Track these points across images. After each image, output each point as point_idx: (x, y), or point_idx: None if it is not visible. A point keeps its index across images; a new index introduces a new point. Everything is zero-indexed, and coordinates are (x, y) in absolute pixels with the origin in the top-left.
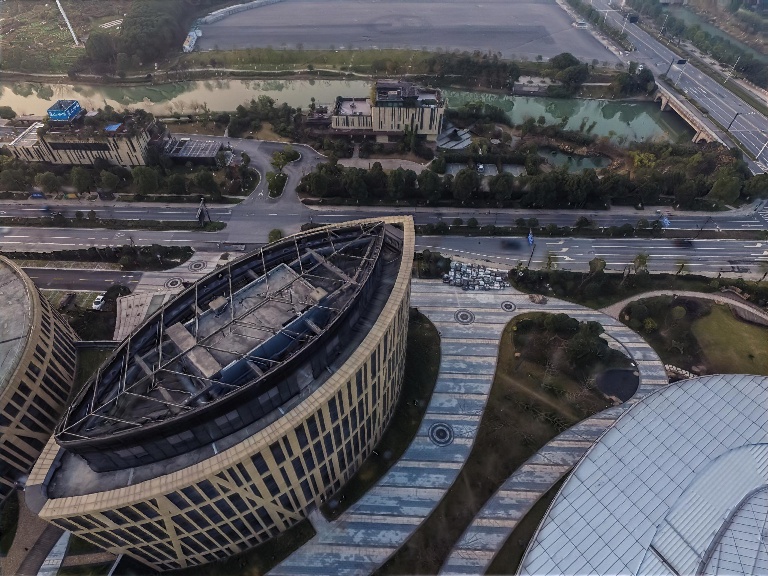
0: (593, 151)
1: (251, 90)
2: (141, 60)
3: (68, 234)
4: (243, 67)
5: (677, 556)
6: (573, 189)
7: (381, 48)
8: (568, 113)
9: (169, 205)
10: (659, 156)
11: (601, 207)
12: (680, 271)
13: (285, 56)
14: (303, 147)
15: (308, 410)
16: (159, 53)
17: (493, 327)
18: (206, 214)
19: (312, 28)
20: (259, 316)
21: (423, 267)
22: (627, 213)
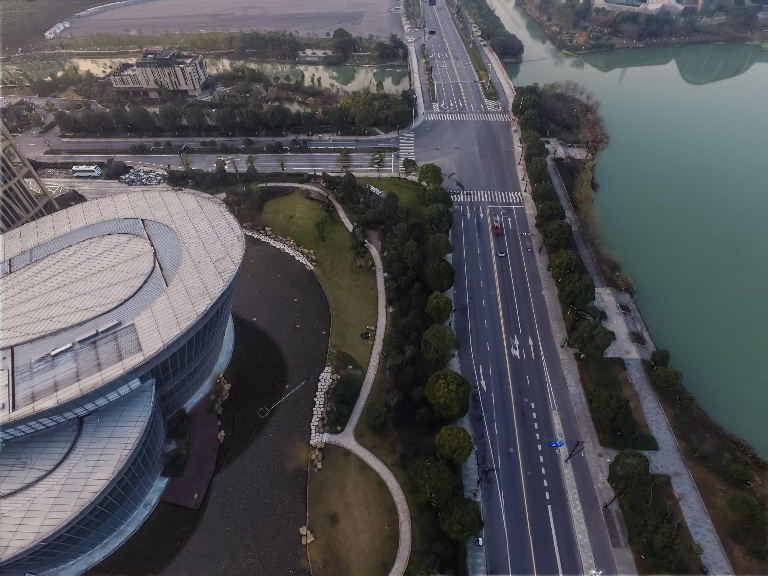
0: (319, 100)
1: (101, 69)
2: (6, 45)
3: None
4: (89, 49)
5: (19, 262)
6: (244, 118)
7: (207, 31)
8: (348, 79)
9: None
10: None
11: (279, 134)
12: (283, 168)
13: (126, 39)
14: (91, 102)
15: None
16: (21, 39)
17: None
18: None
19: (165, 18)
20: None
21: (103, 170)
22: None
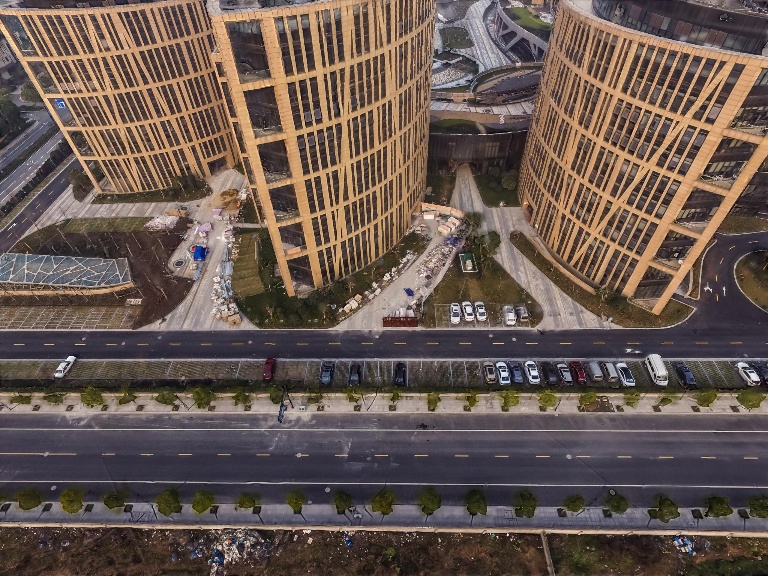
0: None
1: None
2: None
3: (3, 188)
4: None
5: None
6: None
7: None
8: None
9: (6, 148)
10: None
11: None
12: None
13: None
14: None
15: None
16: None
17: None
18: (38, 132)
19: None
20: None
21: None
22: None
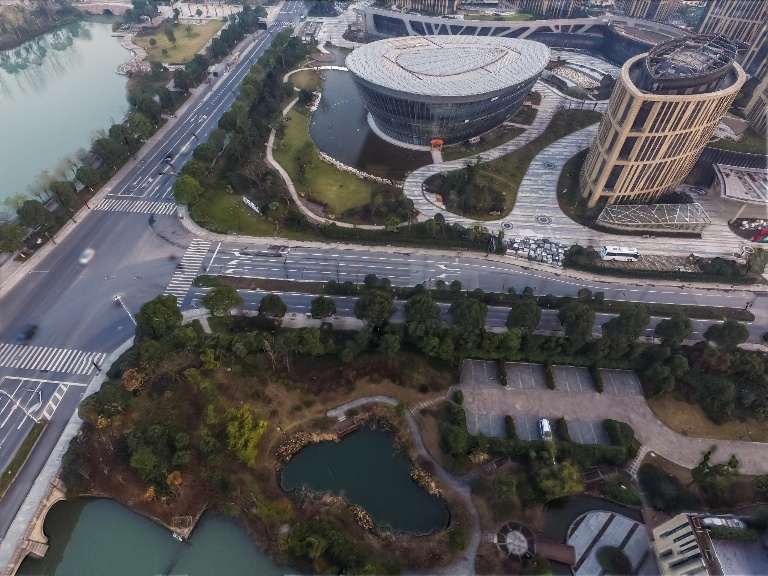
0: None
1: None
2: None
3: None
4: None
5: None
6: None
7: None
8: None
9: None
10: (217, 431)
11: None
12: (355, 226)
13: None
14: None
15: (640, 55)
16: None
17: (520, 212)
18: None
19: None
20: (688, 59)
21: None
22: (348, 319)
